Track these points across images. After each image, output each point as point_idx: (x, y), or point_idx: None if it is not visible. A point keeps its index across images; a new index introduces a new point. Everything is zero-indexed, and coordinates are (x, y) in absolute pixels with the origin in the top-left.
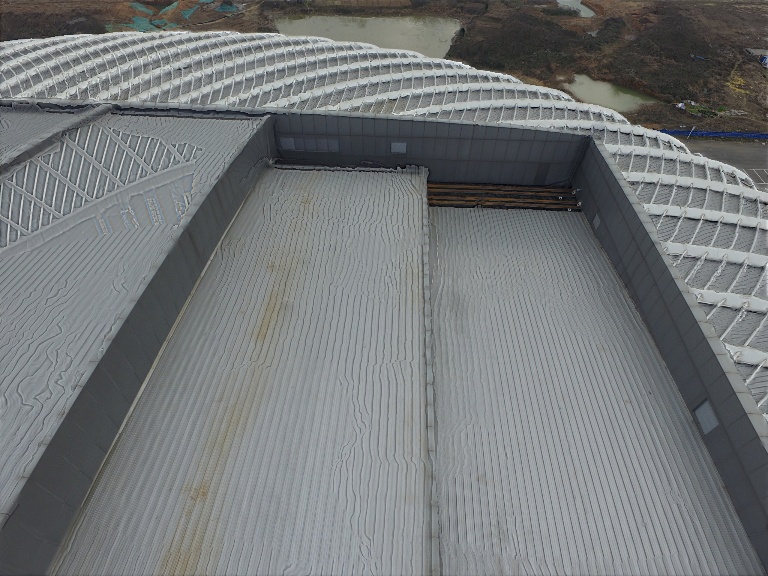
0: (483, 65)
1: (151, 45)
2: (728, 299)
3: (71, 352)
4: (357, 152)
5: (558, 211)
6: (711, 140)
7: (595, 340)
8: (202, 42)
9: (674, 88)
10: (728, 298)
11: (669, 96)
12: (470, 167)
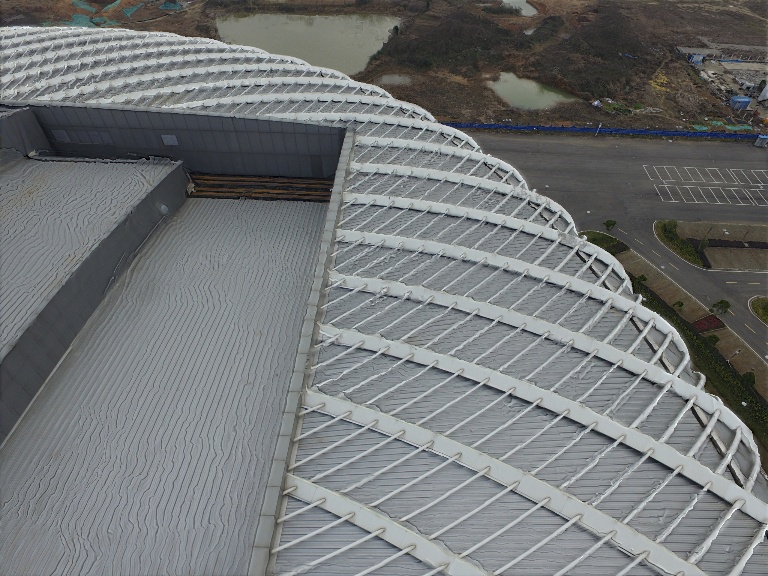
0: (411, 63)
1: None
2: (369, 284)
3: None
4: (130, 144)
5: (320, 202)
6: (619, 137)
7: (259, 325)
8: (31, 37)
9: (593, 86)
10: (369, 283)
11: (588, 94)
12: (245, 159)
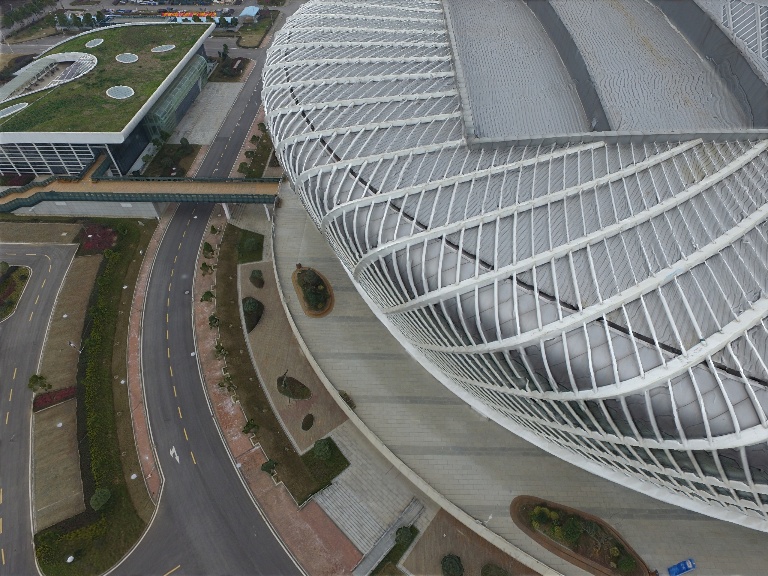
0: None
1: None
2: None
3: None
4: None
5: None
6: None
7: None
8: None
9: None
10: None
11: None
12: None
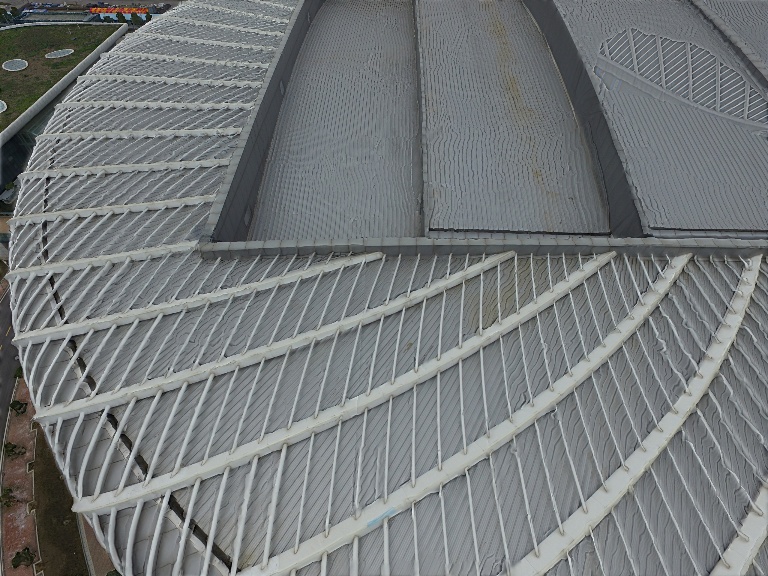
0: None
1: None
2: None
3: None
4: None
5: None
6: None
7: None
8: None
9: None
10: None
11: None
12: None
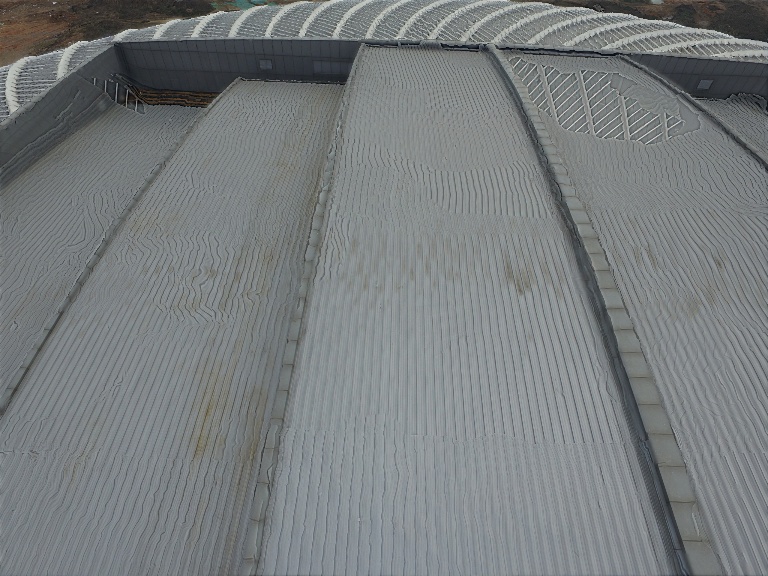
0: None
1: (436, 6)
2: None
3: (761, 164)
4: None
5: None
6: None
7: None
8: (476, 4)
9: None
10: None
11: None
12: None
